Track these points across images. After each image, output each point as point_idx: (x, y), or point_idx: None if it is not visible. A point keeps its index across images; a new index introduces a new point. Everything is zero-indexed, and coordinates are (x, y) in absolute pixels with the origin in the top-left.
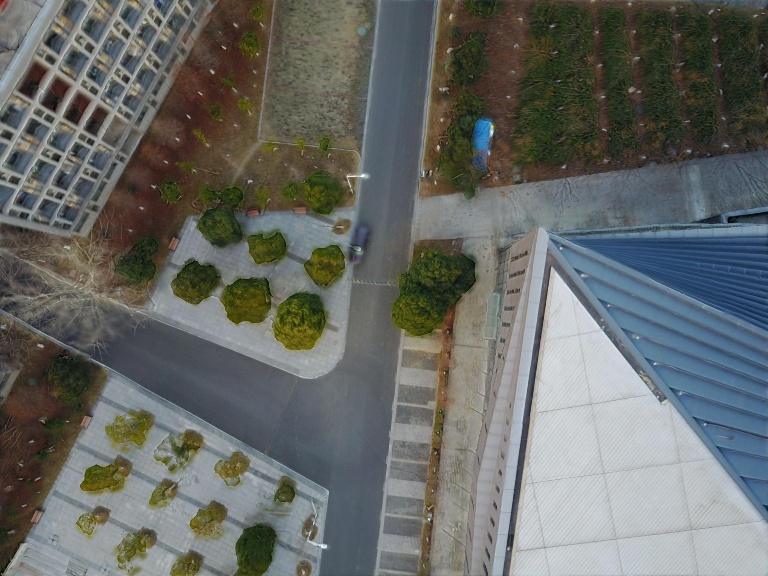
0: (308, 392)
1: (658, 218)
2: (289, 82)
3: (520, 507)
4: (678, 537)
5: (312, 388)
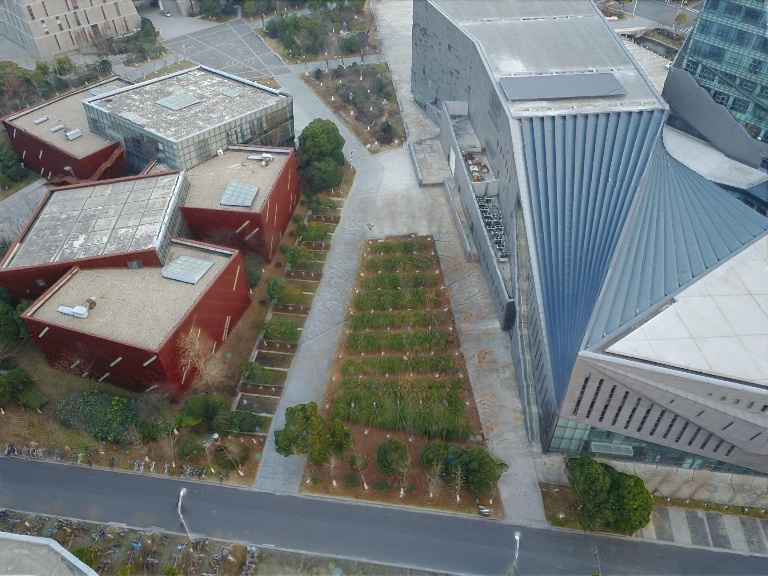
0: None
1: (501, 348)
2: None
3: None
4: (759, 302)
5: None
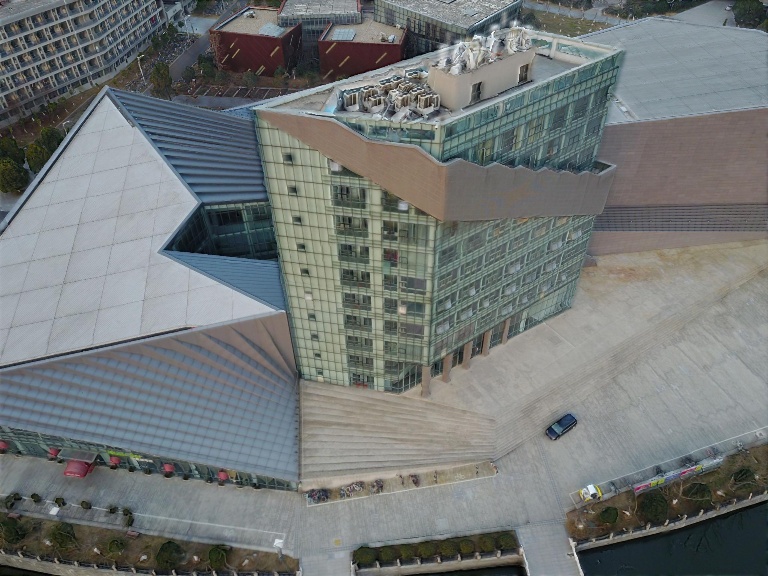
0: (0, 215)
1: None
2: (69, 127)
3: (53, 167)
4: None
5: (4, 214)
